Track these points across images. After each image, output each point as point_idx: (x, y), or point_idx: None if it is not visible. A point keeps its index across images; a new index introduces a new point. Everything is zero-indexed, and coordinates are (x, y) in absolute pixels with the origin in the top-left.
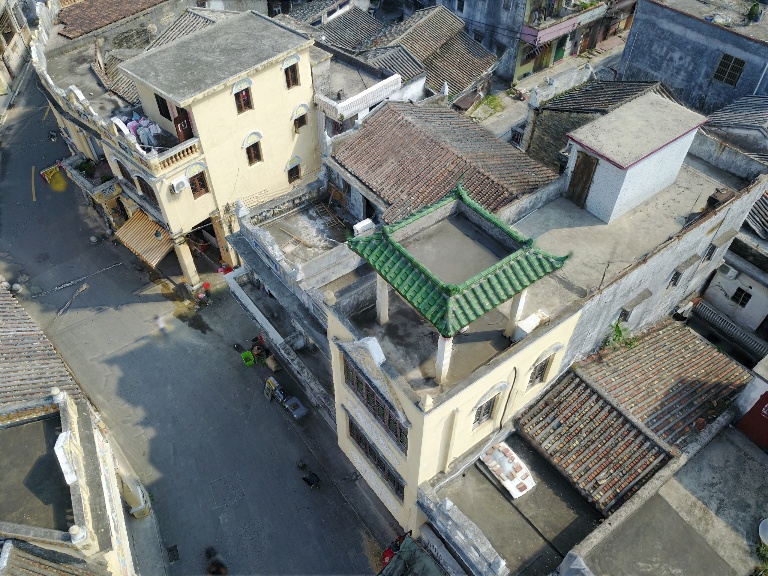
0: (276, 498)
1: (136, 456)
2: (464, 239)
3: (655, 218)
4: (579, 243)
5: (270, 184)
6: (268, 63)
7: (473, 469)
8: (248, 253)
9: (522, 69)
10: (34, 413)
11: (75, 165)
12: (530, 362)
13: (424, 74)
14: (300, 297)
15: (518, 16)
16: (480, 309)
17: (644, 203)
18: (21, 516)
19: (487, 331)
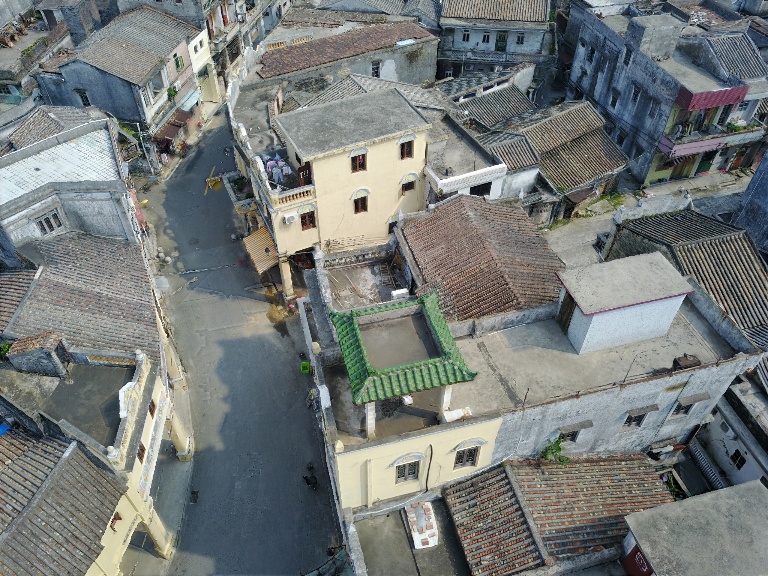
0: (281, 485)
1: (198, 415)
2: (414, 336)
3: (625, 362)
4: (543, 363)
5: (371, 231)
6: (385, 138)
7: (397, 514)
8: (313, 288)
9: (657, 174)
10: (123, 362)
11: (232, 179)
12: (450, 445)
13: (538, 166)
14: (333, 335)
15: (660, 126)
16: (391, 392)
17: (624, 346)
18: (90, 428)
19: (426, 410)
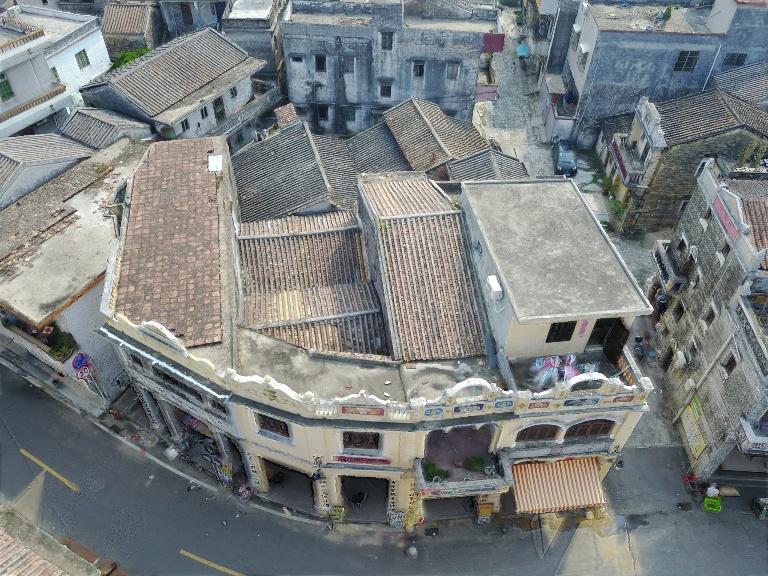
0: None
1: None
2: None
3: None
4: None
5: None
6: None
7: None
8: None
9: None
10: None
11: None
12: None
13: None
14: None
15: (469, 80)
16: None
17: None
18: None
19: None
